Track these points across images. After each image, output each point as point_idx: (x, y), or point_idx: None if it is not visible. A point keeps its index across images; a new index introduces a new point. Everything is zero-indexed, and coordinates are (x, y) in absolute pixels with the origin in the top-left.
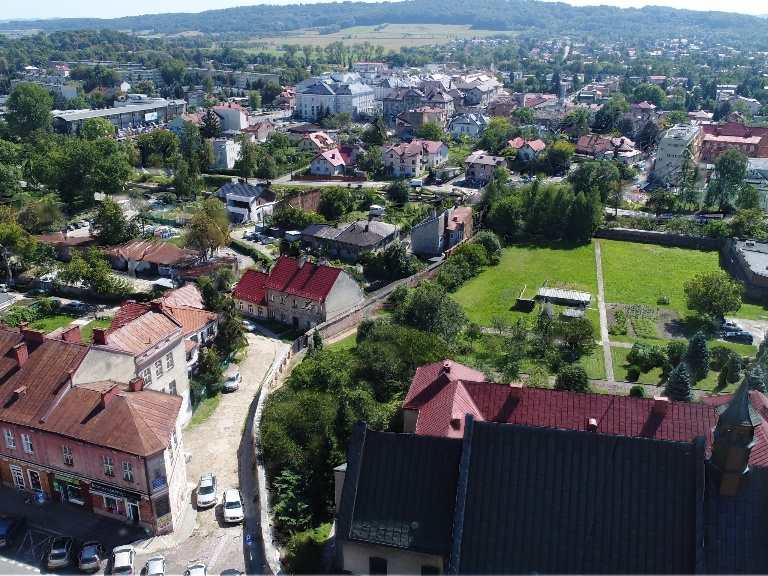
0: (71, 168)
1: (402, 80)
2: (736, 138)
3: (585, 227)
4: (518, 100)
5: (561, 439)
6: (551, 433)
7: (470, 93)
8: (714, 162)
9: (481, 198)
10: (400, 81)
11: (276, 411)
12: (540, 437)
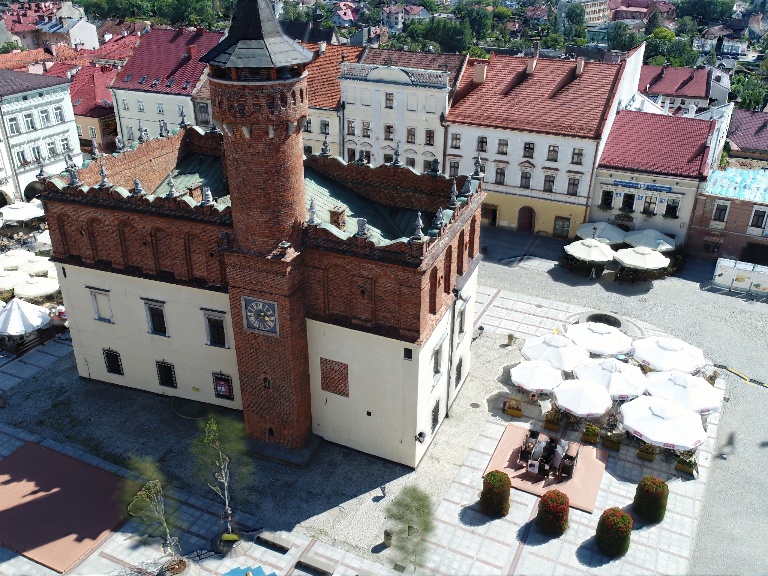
0: (177, 8)
1: None
2: (640, 9)
3: (459, 44)
4: None
5: None
6: None
7: None
8: (565, 12)
9: (407, 28)
10: None
11: None
12: None
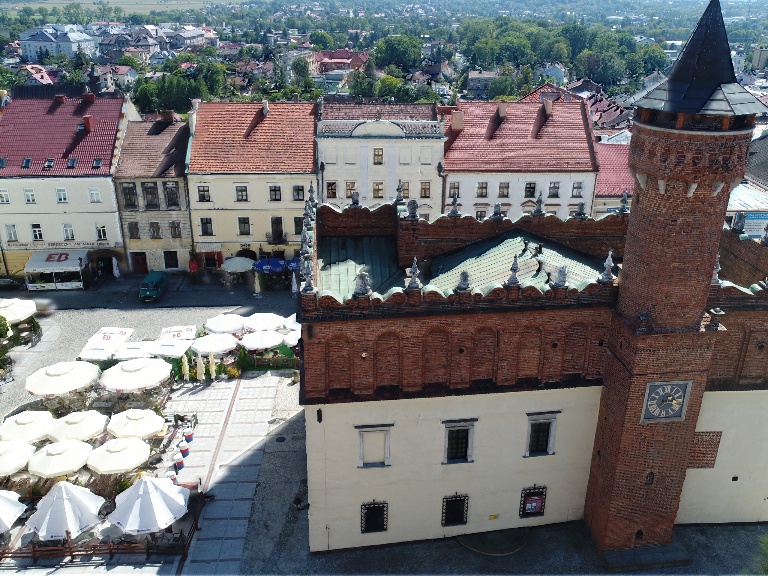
0: None
1: (113, 28)
2: (342, 60)
3: None
4: (212, 43)
5: (43, 87)
6: (40, 86)
7: (175, 39)
8: (290, 65)
9: (134, 89)
10: (111, 29)
11: None
12: (36, 87)
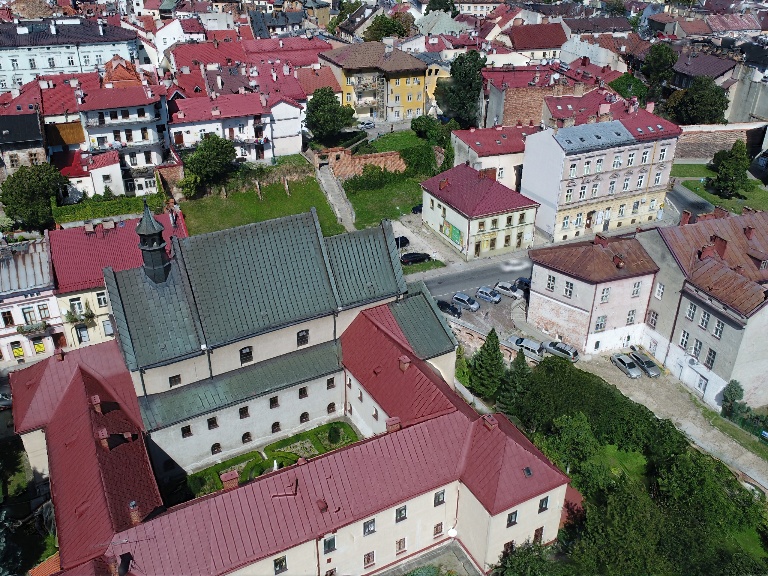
0: None
1: None
2: None
3: None
4: None
5: None
6: None
7: None
8: None
9: None
10: None
11: (608, 385)
12: None
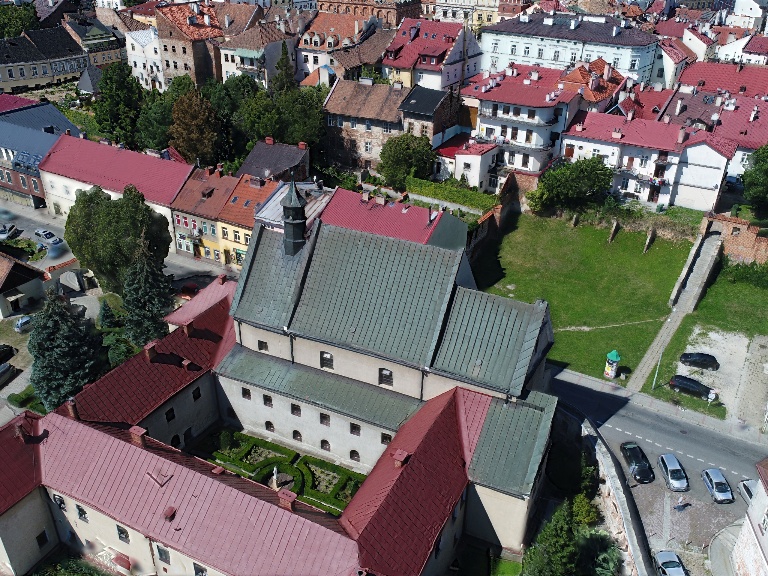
0: None
1: None
2: None
3: None
4: None
5: None
6: None
7: None
8: None
9: None
10: None
11: None
12: None
